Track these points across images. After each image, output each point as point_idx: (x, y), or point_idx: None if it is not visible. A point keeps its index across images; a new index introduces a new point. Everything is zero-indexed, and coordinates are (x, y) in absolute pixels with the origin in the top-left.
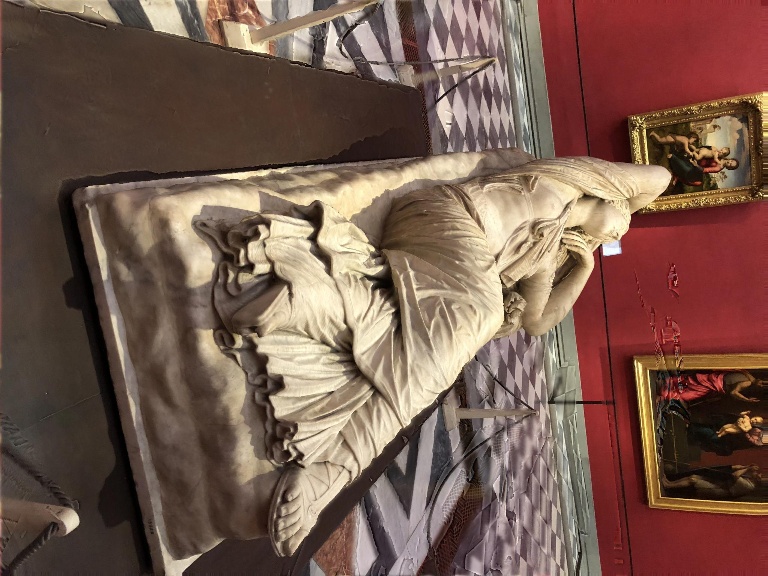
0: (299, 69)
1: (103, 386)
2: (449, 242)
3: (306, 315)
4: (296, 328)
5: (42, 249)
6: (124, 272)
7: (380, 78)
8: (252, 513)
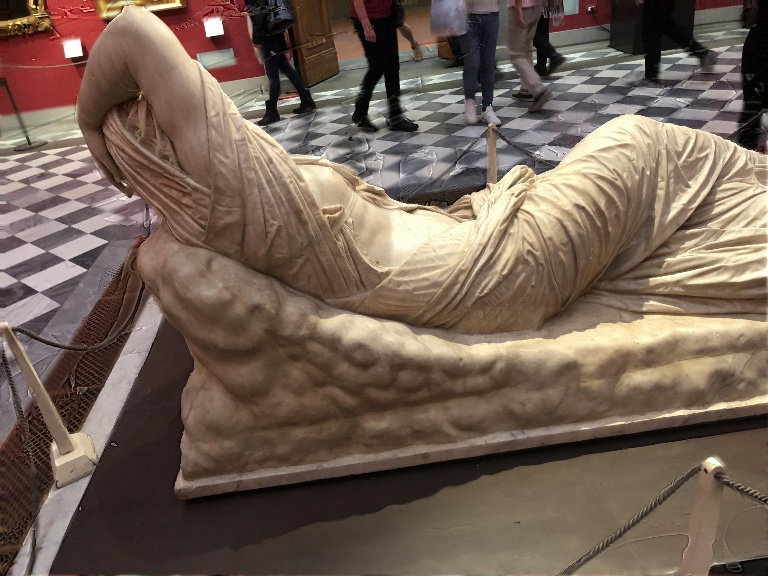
0: (597, 575)
1: None
2: None
3: None
4: None
5: None
6: None
7: None
8: None
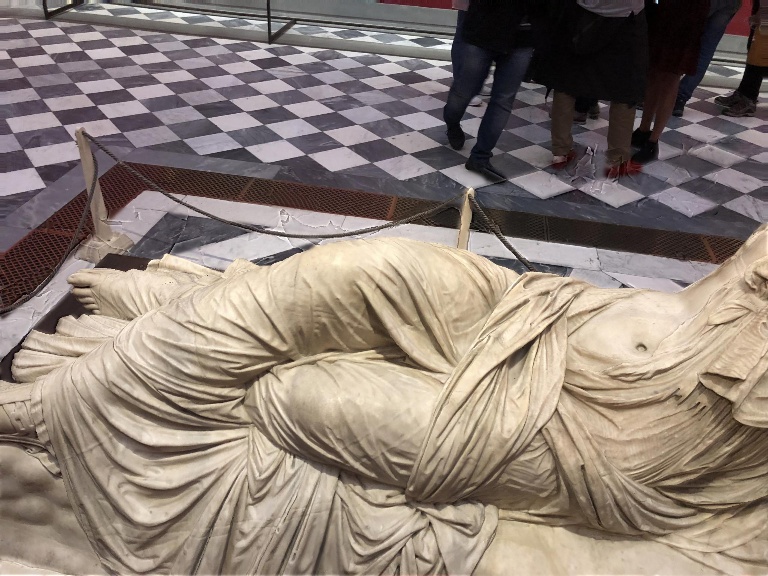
0: None
1: None
2: None
3: (129, 287)
4: (127, 306)
5: None
6: None
7: None
8: None
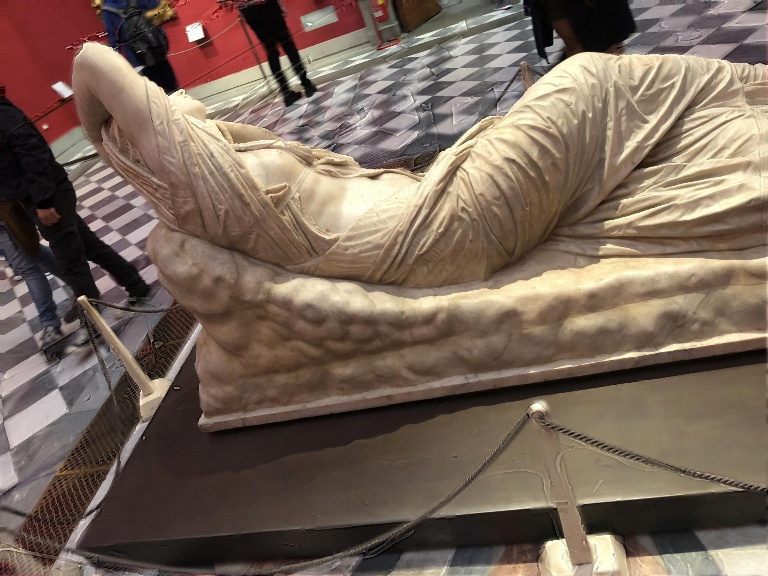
0: None
1: None
2: (572, 141)
3: None
4: None
5: None
6: None
7: (224, 545)
8: None
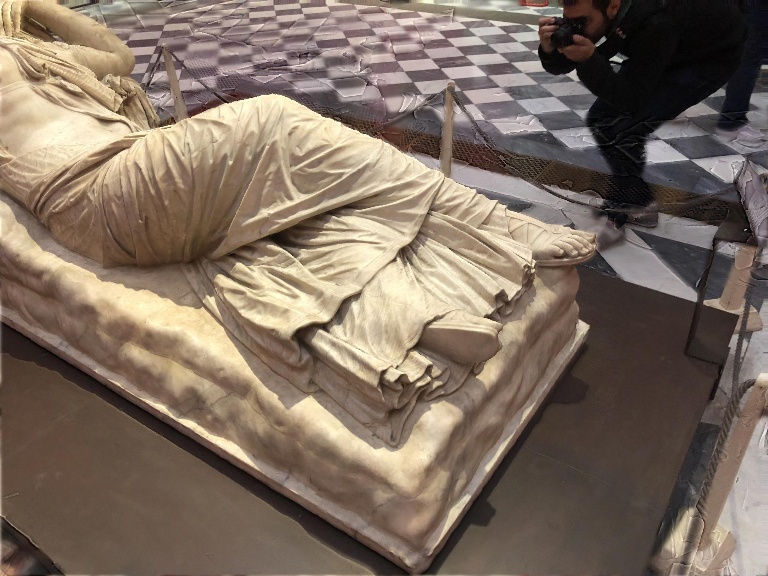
0: None
1: (517, 446)
2: (199, 179)
3: None
4: None
5: (480, 563)
6: (461, 483)
7: None
8: (569, 278)
